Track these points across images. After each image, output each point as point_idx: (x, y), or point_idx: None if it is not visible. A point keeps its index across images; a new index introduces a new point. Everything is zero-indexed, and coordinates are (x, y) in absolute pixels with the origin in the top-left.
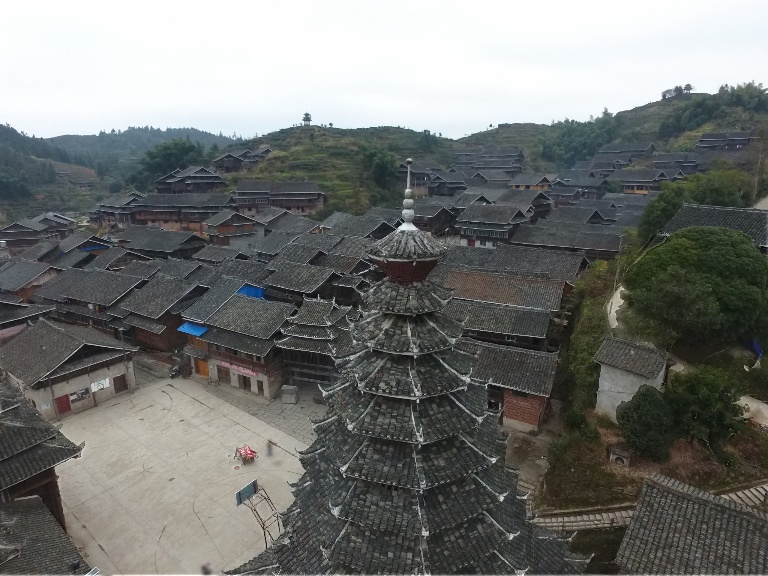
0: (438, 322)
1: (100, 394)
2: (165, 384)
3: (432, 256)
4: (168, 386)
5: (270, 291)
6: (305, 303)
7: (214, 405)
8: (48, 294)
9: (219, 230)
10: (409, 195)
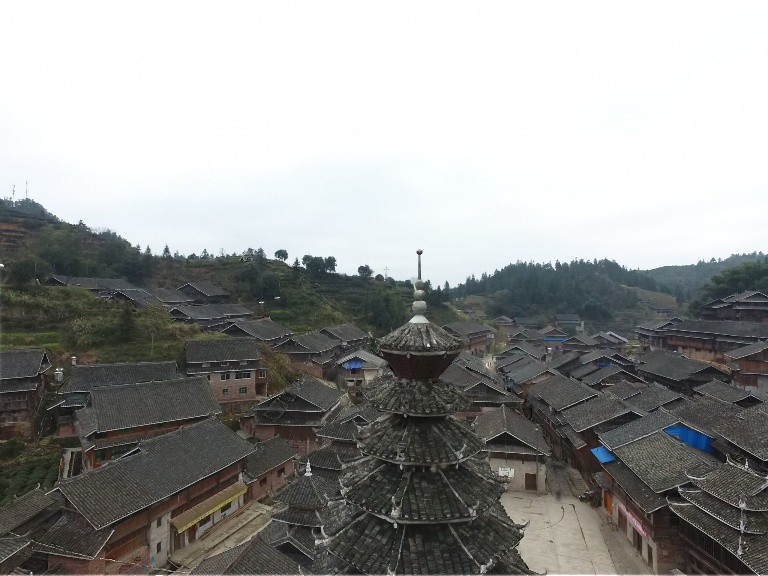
0: (421, 435)
1: (512, 483)
2: (570, 502)
3: (397, 349)
4: (571, 506)
5: (719, 443)
6: (725, 466)
7: (593, 546)
8: (534, 391)
9: (742, 365)
10: (417, 286)
